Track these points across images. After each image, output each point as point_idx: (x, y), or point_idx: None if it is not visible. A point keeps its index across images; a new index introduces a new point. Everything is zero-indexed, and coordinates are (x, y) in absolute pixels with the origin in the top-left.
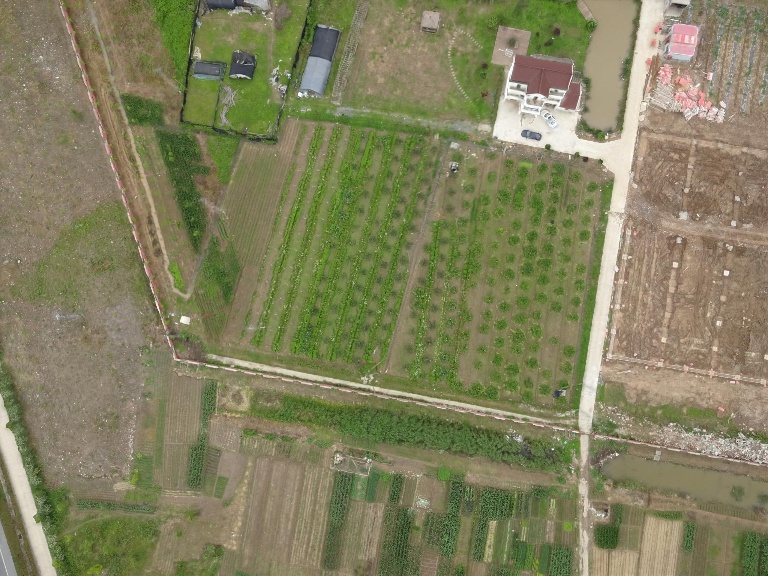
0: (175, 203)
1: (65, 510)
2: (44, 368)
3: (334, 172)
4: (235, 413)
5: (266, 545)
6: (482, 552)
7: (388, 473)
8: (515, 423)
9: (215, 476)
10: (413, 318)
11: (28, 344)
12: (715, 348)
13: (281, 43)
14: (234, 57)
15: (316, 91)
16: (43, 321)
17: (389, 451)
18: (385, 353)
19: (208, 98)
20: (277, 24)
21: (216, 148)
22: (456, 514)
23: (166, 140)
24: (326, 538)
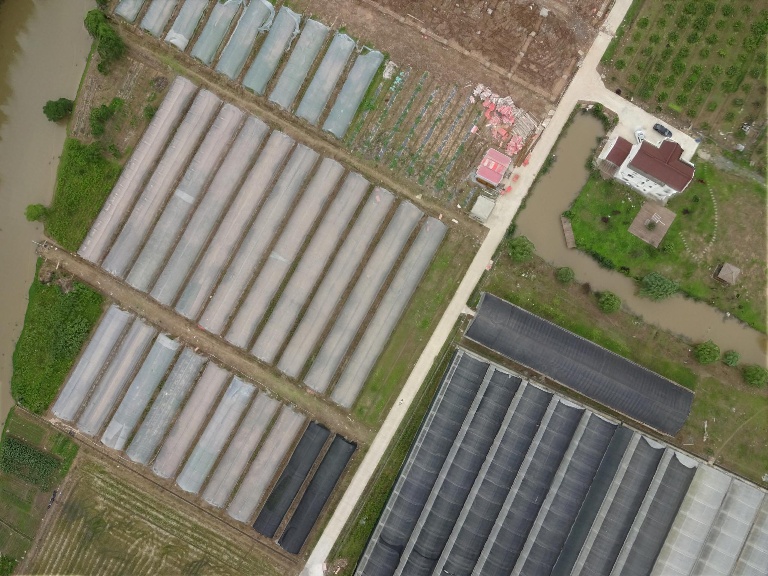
0: None
1: None
2: None
3: None
4: None
5: None
6: None
7: None
8: None
9: None
10: None
11: None
12: None
13: None
14: None
15: None
16: None
17: None
18: None
19: None
20: None
21: None
22: None
23: None
24: None
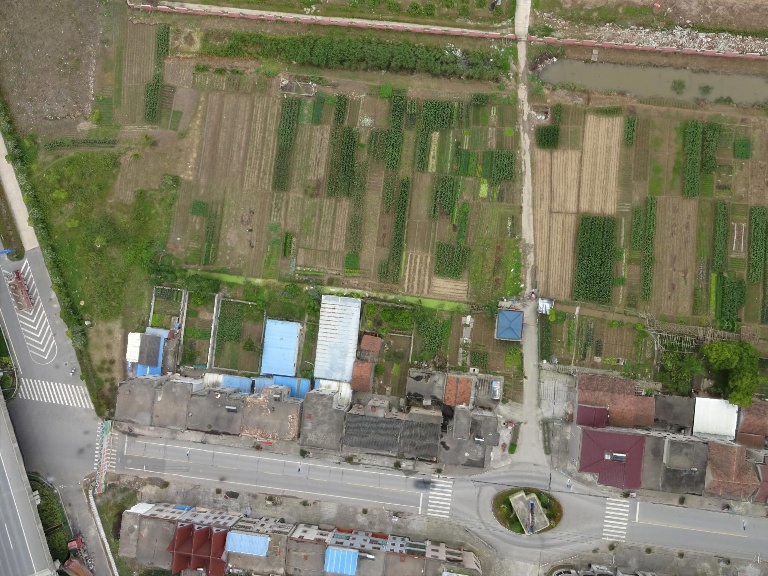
0: None
1: (34, 155)
2: (11, 23)
3: None
4: (187, 53)
5: (220, 174)
6: (426, 160)
7: (333, 96)
8: (453, 37)
9: (170, 111)
10: None
11: None
12: None
13: None
14: None
15: None
16: None
17: (333, 75)
18: None
19: None
20: None
21: None
22: (399, 126)
23: None
24: (276, 161)
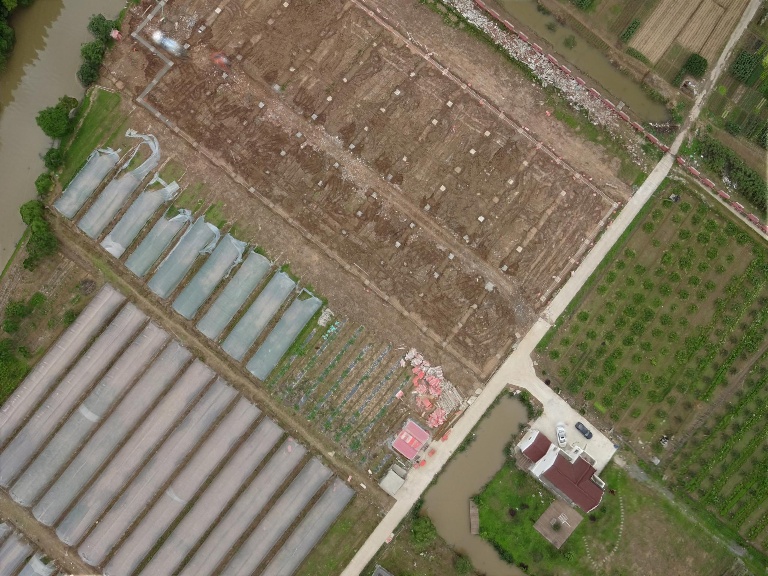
0: None
1: None
2: None
3: None
4: None
5: None
6: None
7: None
8: None
9: None
10: None
11: None
12: (525, 164)
13: None
14: None
15: None
16: None
17: None
18: None
19: None
20: None
21: None
22: None
23: None
24: None
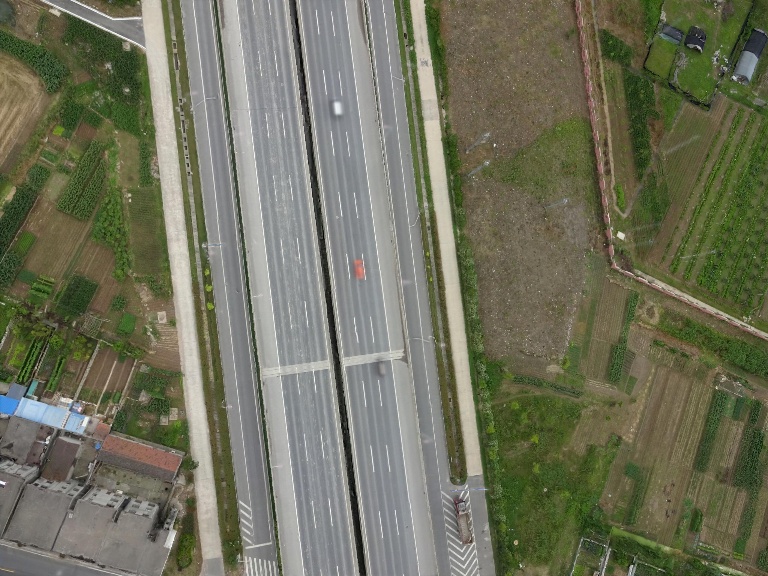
0: (628, 134)
1: (498, 382)
2: (507, 247)
3: (746, 147)
4: (648, 324)
5: (654, 443)
6: None
7: (750, 398)
8: None
9: (628, 375)
10: None
11: (495, 221)
12: None
13: (724, 32)
14: (693, 31)
15: (749, 79)
16: (513, 204)
17: (754, 380)
18: (762, 301)
19: (666, 56)
20: (724, 16)
21: (668, 99)
22: None
23: (632, 79)
24: (701, 444)
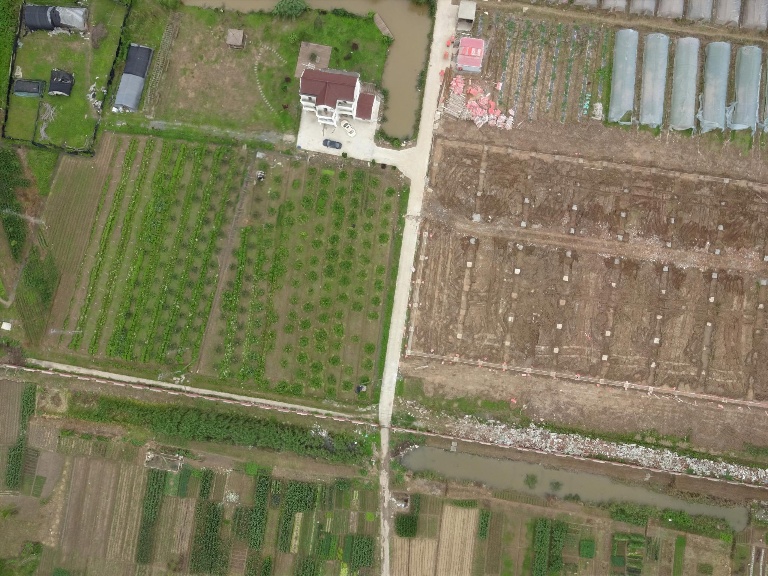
0: None
1: None
2: None
3: (148, 182)
4: (53, 414)
5: (83, 541)
6: (288, 543)
7: (199, 469)
8: (319, 418)
9: (33, 476)
10: (222, 320)
11: None
12: (507, 343)
13: (98, 61)
14: (52, 75)
15: (128, 106)
16: None
17: (200, 448)
18: (196, 354)
19: (29, 114)
20: (94, 43)
21: (35, 161)
22: (263, 507)
23: None
24: (140, 533)
